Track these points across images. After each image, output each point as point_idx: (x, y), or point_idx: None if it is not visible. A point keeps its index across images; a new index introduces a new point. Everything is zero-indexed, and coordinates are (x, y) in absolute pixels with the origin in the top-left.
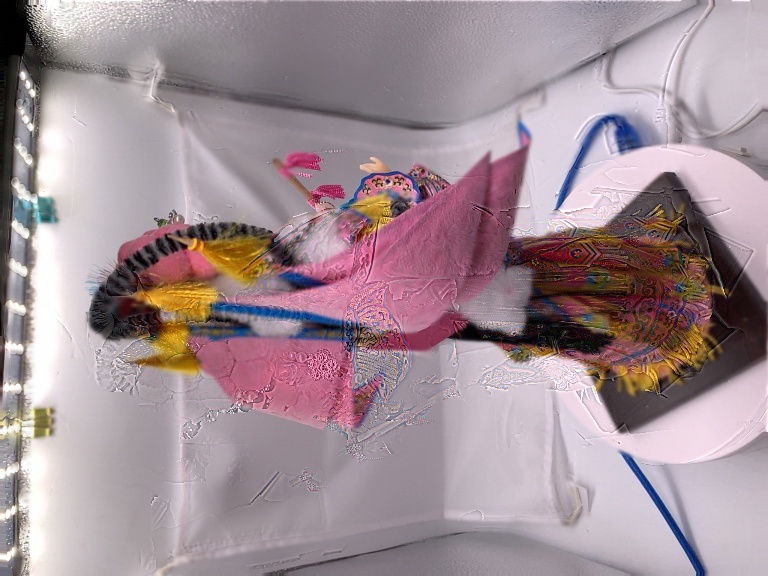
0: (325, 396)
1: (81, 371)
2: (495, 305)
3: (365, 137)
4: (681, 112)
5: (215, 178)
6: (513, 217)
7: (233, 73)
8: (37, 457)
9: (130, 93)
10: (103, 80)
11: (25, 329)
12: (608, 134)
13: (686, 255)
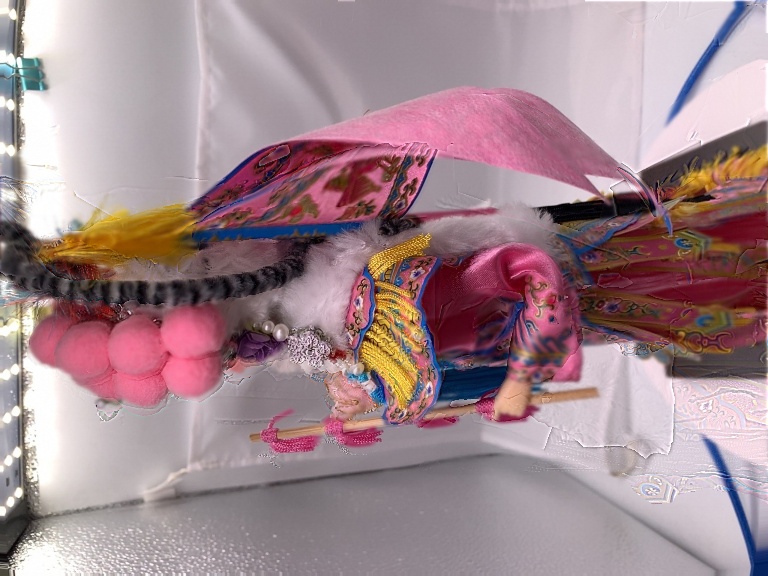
0: None
1: None
2: None
3: None
4: None
5: None
6: (697, 303)
7: None
8: None
9: None
10: None
11: None
12: None
13: None
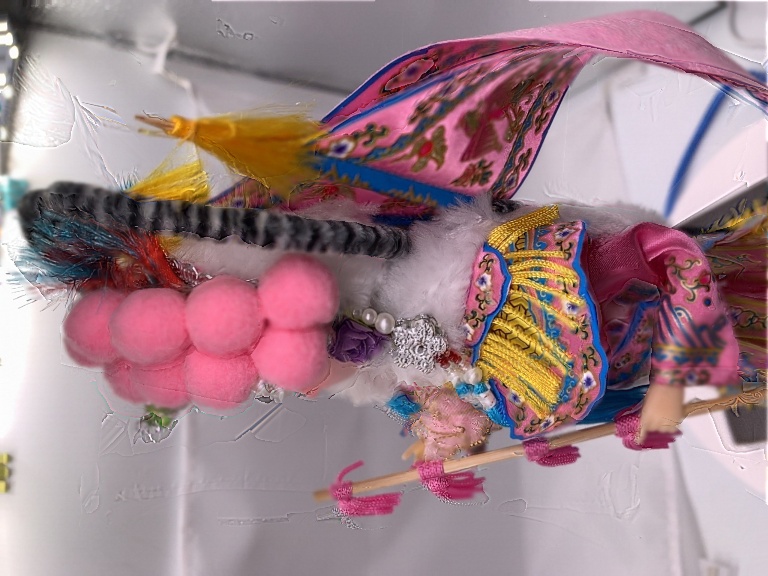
0: None
1: None
2: None
3: None
4: None
5: None
6: None
7: None
8: None
9: None
10: None
11: None
12: None
13: None
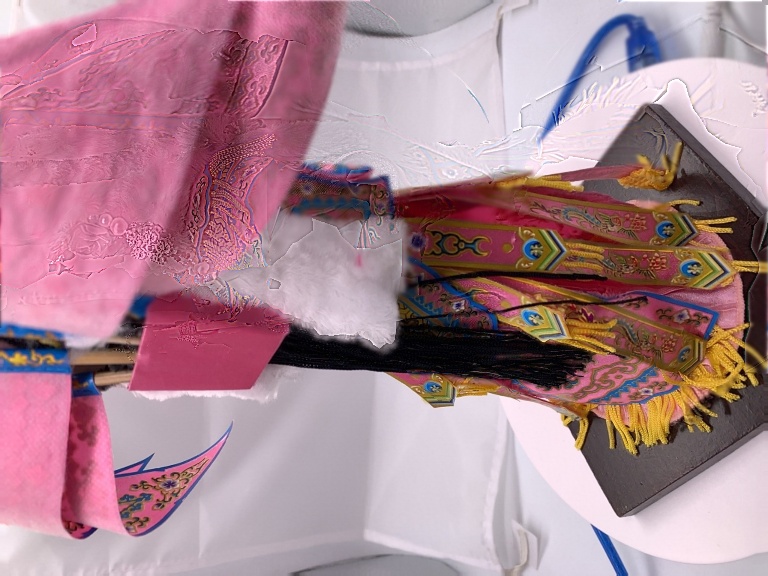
0: None
1: None
2: None
3: None
4: None
5: None
6: (457, 206)
7: None
8: None
9: None
10: None
11: None
12: None
13: (719, 329)
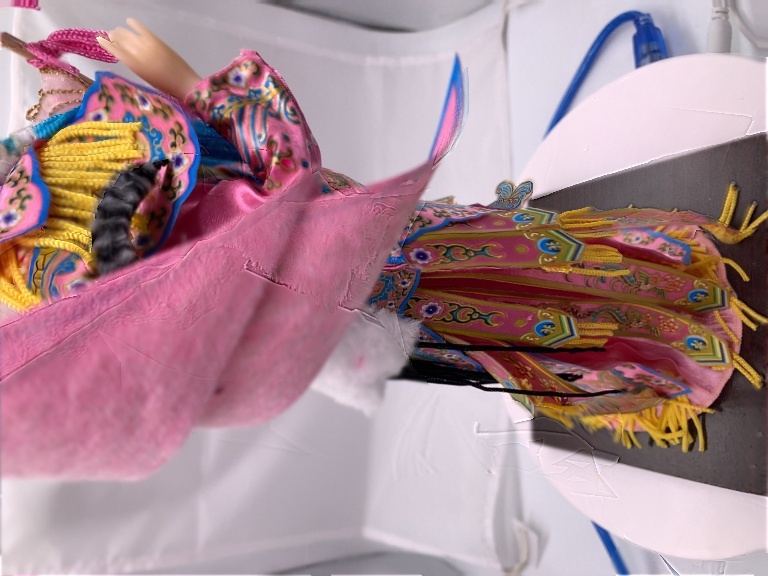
0: None
1: None
2: None
3: None
4: (707, 568)
5: None
6: None
7: None
8: None
9: None
10: None
11: None
12: None
13: None
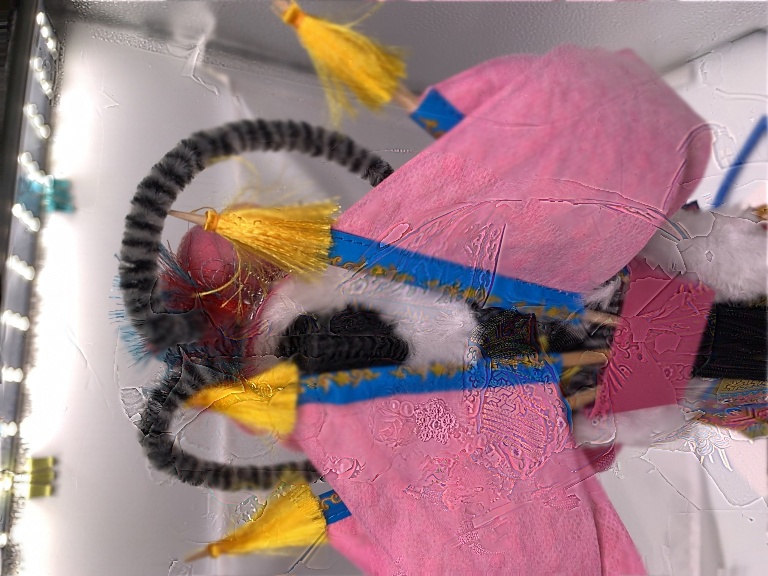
0: (425, 459)
1: (96, 407)
2: (765, 356)
3: (436, 136)
4: None
5: (261, 175)
6: None
7: (289, 54)
8: (32, 526)
9: (168, 72)
10: (137, 55)
11: (27, 348)
12: (717, 146)
13: None
